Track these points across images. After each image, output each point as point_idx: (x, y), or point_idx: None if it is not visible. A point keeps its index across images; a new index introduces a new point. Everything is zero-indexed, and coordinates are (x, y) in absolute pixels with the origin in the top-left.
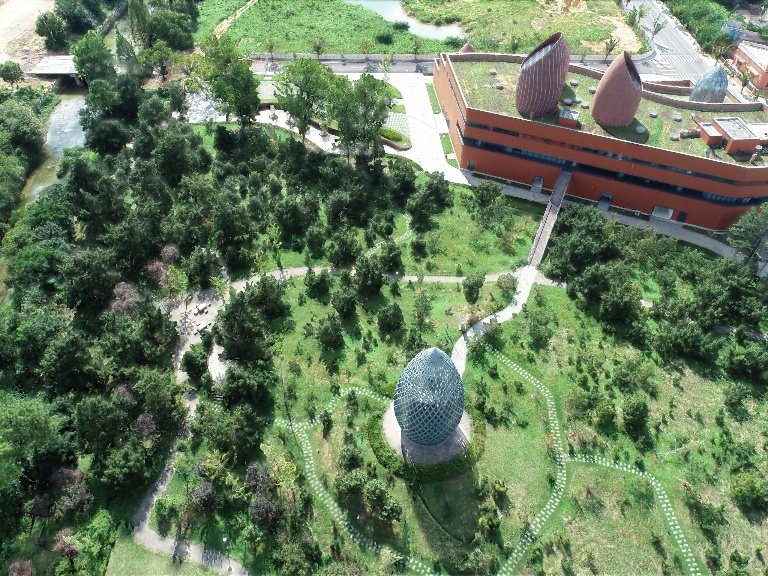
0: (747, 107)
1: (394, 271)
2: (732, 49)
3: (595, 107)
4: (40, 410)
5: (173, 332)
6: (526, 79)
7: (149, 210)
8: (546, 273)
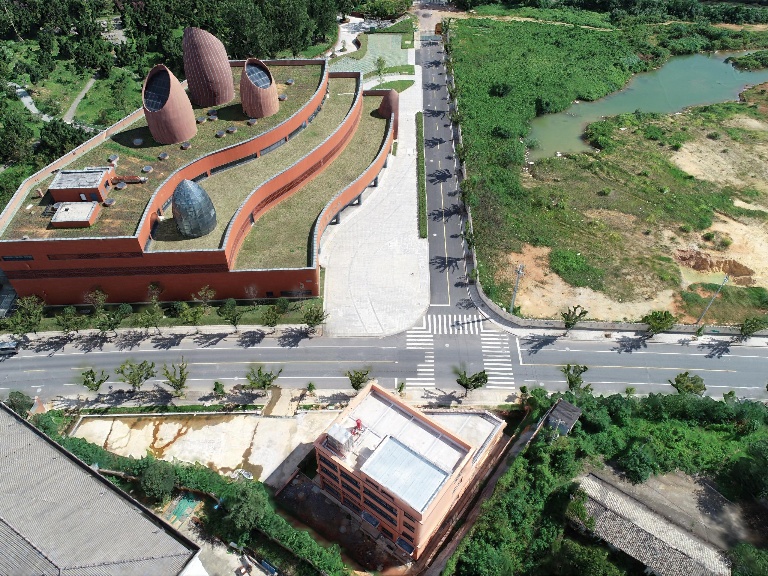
0: None
1: (101, 76)
2: (516, 429)
3: None
4: None
5: (83, 13)
6: None
7: None
8: None
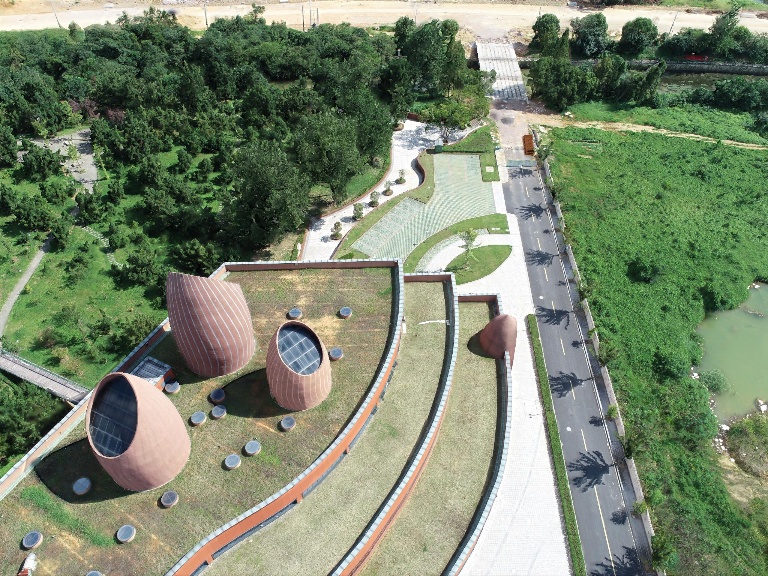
0: None
1: None
2: None
3: None
4: None
5: None
6: None
7: (152, 92)
8: None
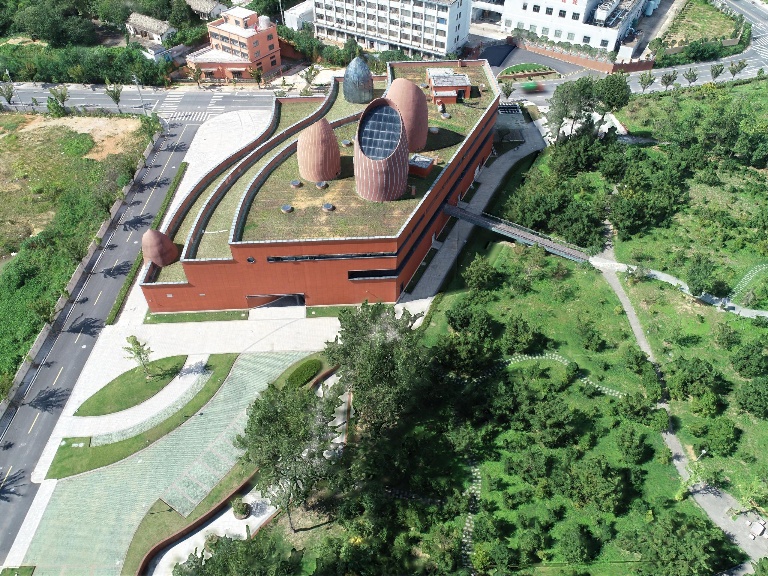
0: None
1: None
2: (181, 69)
3: (410, 142)
4: None
5: None
6: (397, 163)
7: None
8: None
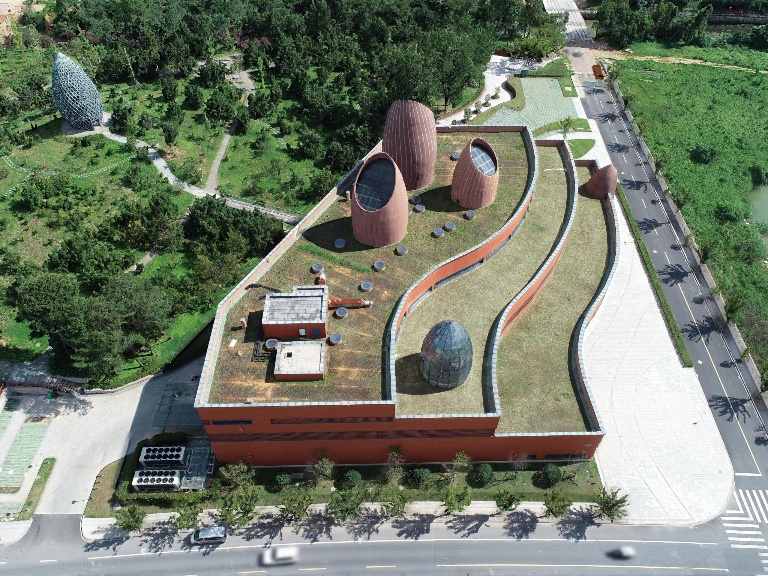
0: None
1: (237, 131)
2: None
3: None
4: (136, 6)
5: (201, 51)
6: None
7: (292, 22)
8: None
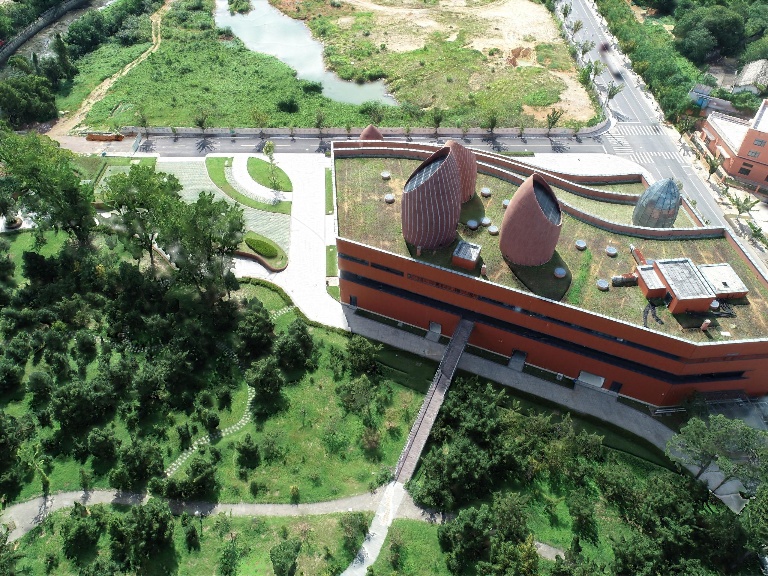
0: (704, 232)
1: (204, 497)
2: (700, 120)
3: (502, 240)
4: None
5: None
6: (408, 206)
7: None
8: (415, 499)
